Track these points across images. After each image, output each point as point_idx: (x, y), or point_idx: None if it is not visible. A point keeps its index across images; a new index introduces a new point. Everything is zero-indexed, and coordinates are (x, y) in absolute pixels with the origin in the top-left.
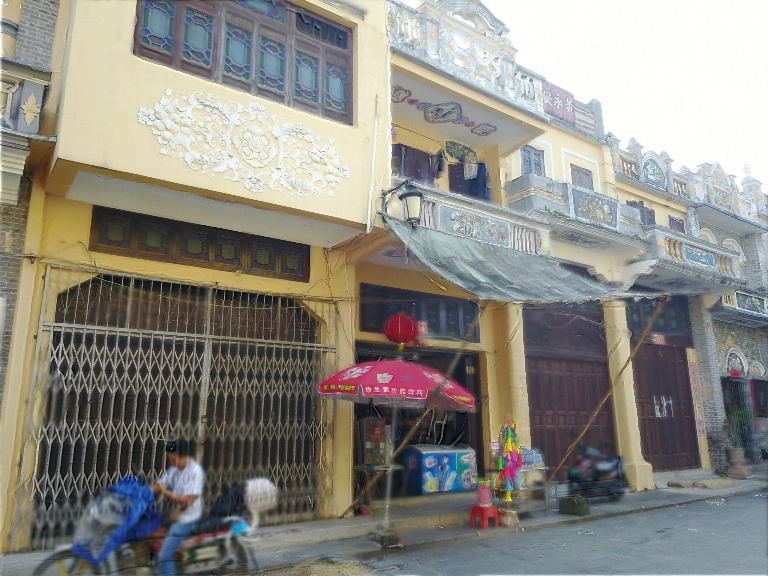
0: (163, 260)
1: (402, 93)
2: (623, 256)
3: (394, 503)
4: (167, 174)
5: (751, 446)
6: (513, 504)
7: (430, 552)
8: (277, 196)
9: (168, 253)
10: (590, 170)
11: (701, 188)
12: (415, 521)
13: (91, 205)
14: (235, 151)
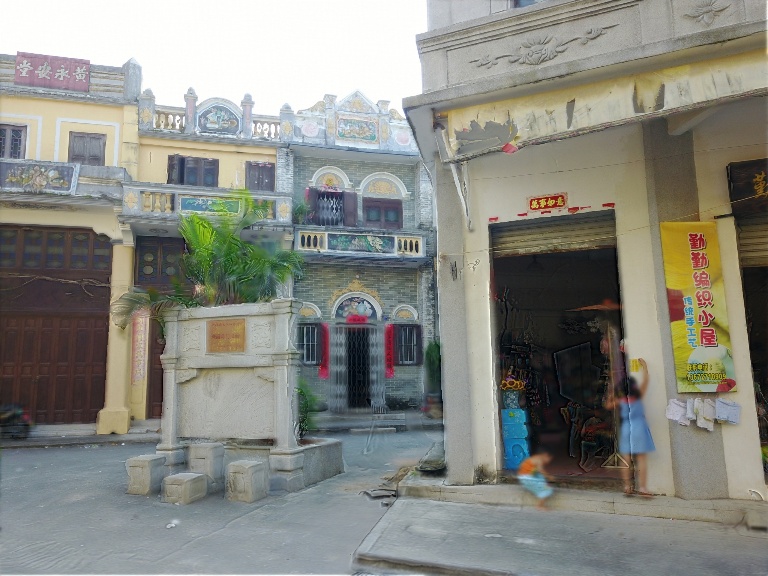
0: None
1: None
2: None
3: None
4: None
5: (365, 395)
6: None
7: None
8: None
9: None
10: (104, 133)
11: (314, 124)
12: None
13: None
14: None
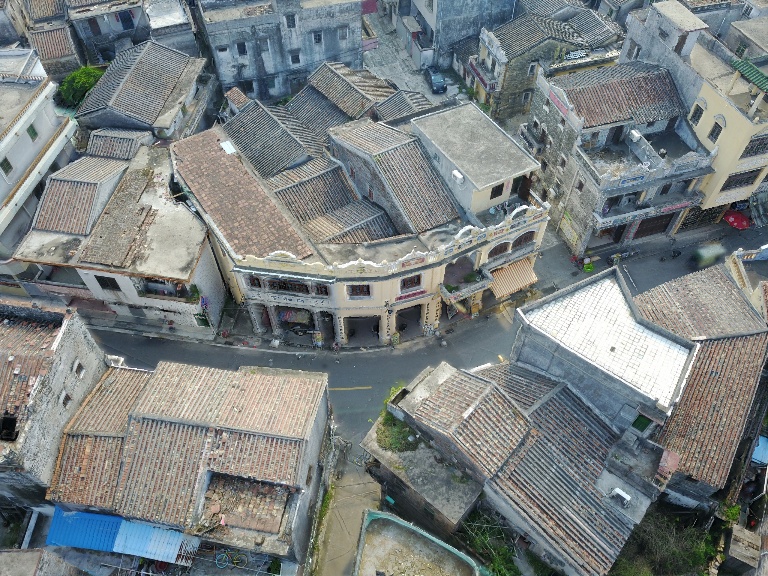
0: None
1: None
2: None
3: None
4: None
5: None
6: None
7: None
8: None
9: None
10: None
11: None
12: None
13: None
14: None
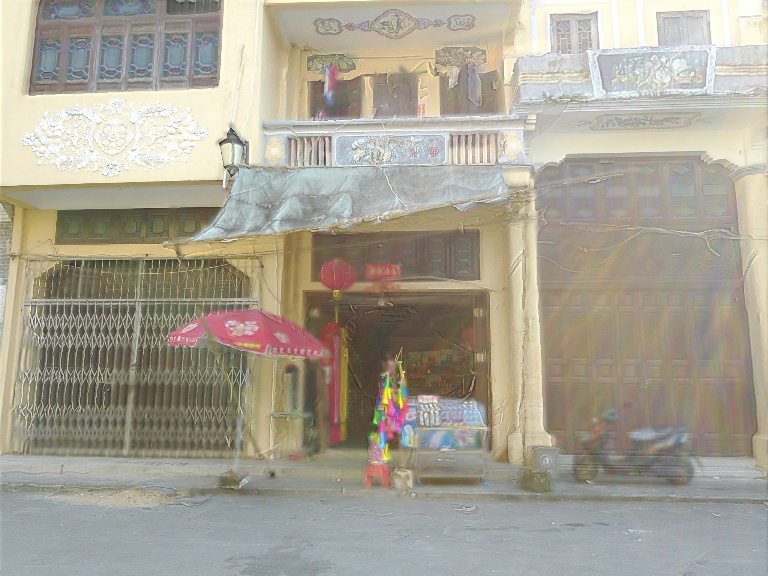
0: (106, 243)
1: (331, 23)
2: (756, 124)
3: (351, 453)
4: (42, 179)
5: None
6: (442, 467)
7: (261, 498)
8: (132, 175)
9: (109, 236)
10: (705, 9)
11: None
12: (310, 470)
13: (56, 210)
14: (96, 146)
